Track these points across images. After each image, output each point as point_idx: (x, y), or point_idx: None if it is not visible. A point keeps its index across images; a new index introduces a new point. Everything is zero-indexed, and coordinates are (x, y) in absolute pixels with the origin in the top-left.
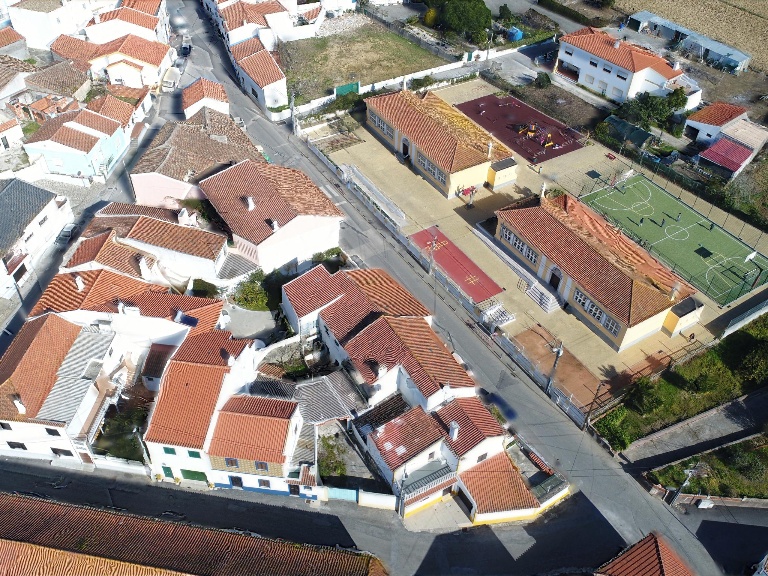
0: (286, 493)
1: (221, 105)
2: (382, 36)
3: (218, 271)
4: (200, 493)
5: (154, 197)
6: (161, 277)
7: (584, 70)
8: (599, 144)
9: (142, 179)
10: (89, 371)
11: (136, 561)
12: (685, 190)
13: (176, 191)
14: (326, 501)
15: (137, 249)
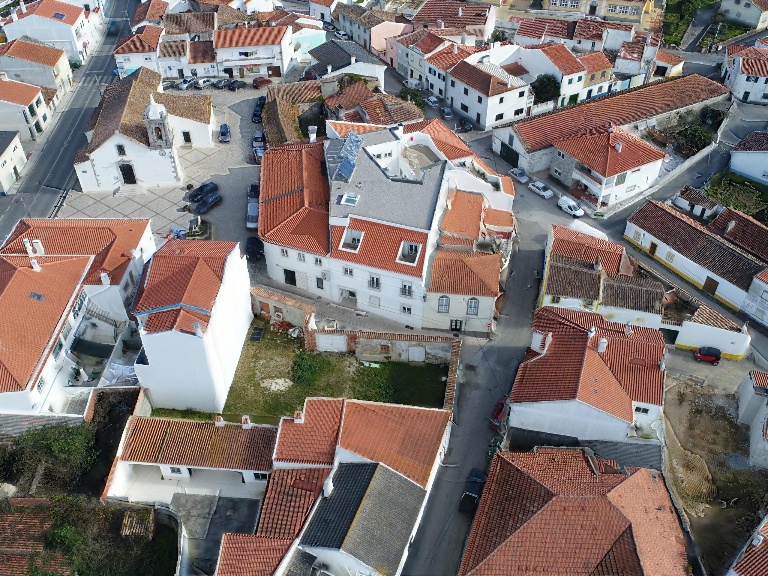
0: None
1: (344, 0)
2: None
3: None
4: None
5: (382, 42)
6: None
7: None
8: None
9: (377, 29)
10: None
11: None
12: None
13: (395, 32)
14: None
15: None
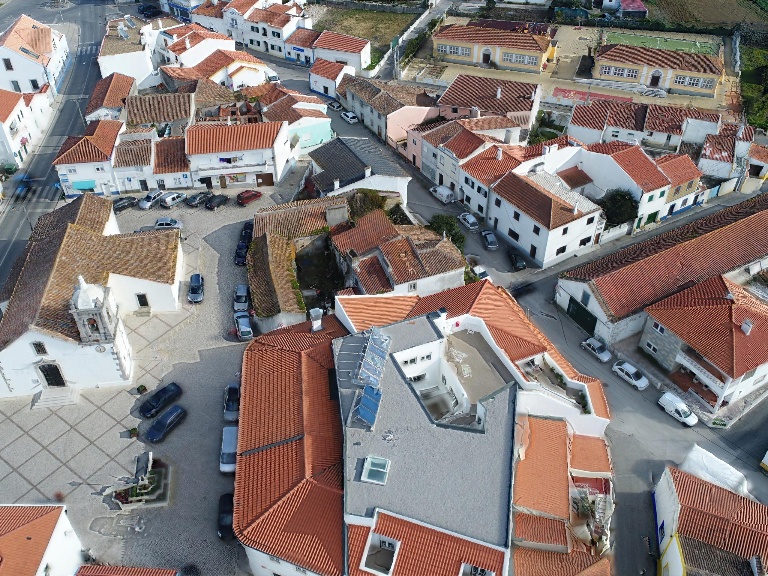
0: (690, 206)
1: (352, 70)
2: (351, 13)
3: None
4: (658, 228)
5: (401, 130)
6: None
7: None
8: (562, 25)
9: (395, 116)
10: None
11: (725, 225)
12: (632, 30)
13: (417, 117)
14: (706, 202)
15: None
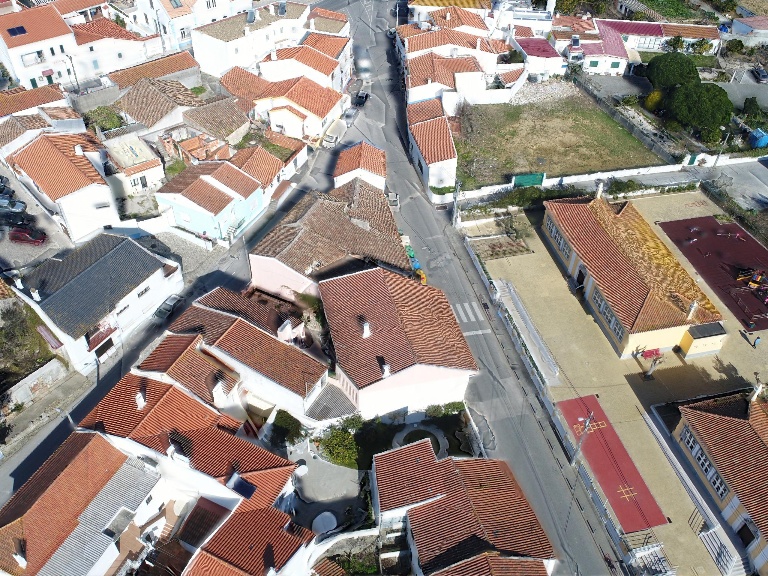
0: None
1: (376, 178)
2: (588, 114)
3: (308, 407)
4: None
5: (270, 282)
6: (238, 404)
7: None
8: None
9: (261, 261)
10: (116, 521)
11: None
12: None
13: (294, 283)
14: None
15: (221, 363)
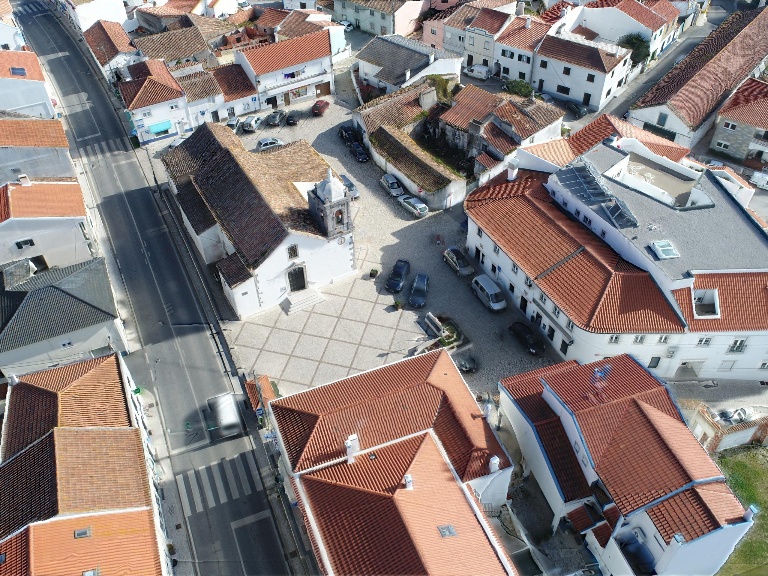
0: None
1: None
2: None
3: None
4: (658, 63)
5: None
6: None
7: None
8: None
9: (400, 13)
10: None
11: (727, 43)
12: None
13: (415, 12)
14: (678, 38)
15: None
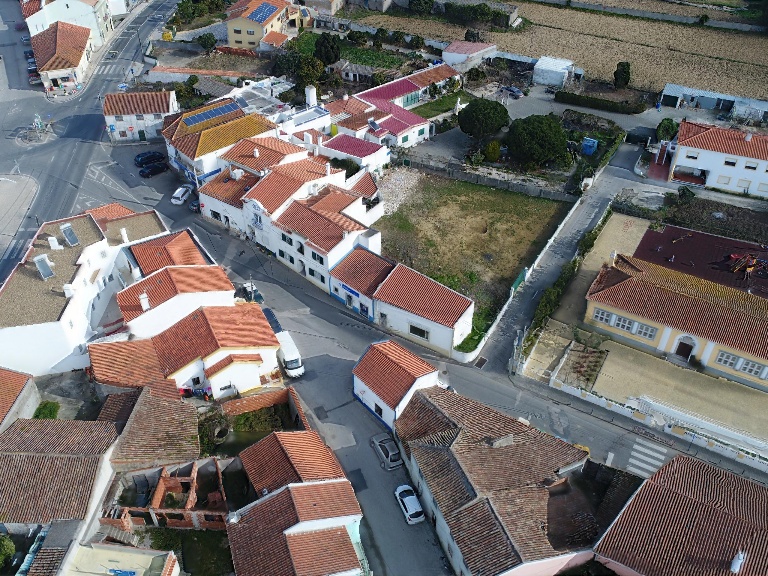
0: None
1: (431, 378)
2: (454, 189)
3: None
4: None
5: None
6: None
7: (716, 172)
8: None
9: None
10: None
11: None
12: None
13: (546, 572)
14: None
15: None
